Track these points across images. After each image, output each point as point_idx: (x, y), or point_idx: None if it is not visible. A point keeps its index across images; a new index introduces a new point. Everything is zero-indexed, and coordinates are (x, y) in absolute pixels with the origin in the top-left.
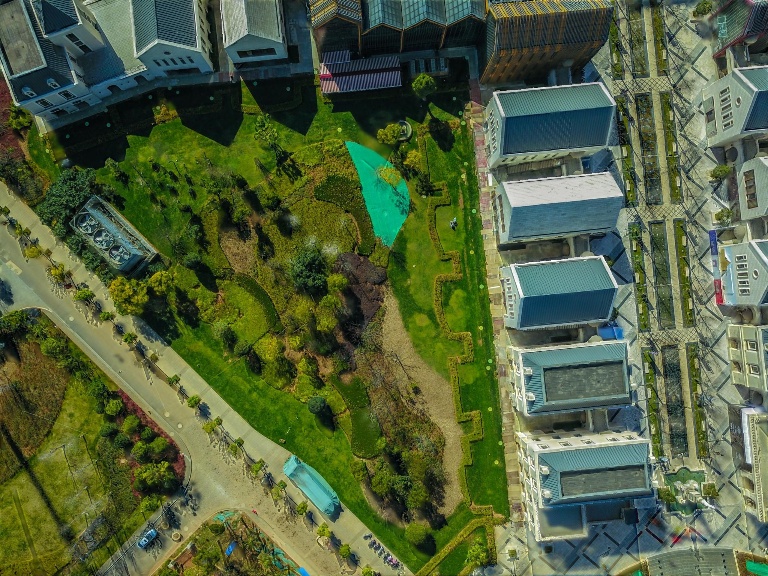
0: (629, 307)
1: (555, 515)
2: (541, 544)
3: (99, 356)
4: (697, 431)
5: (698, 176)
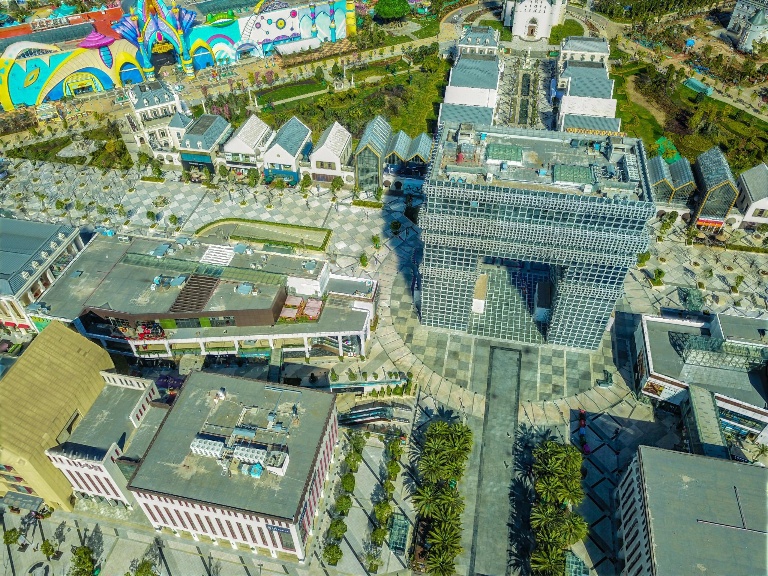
0: (542, 106)
1: None
2: None
3: None
4: None
5: None
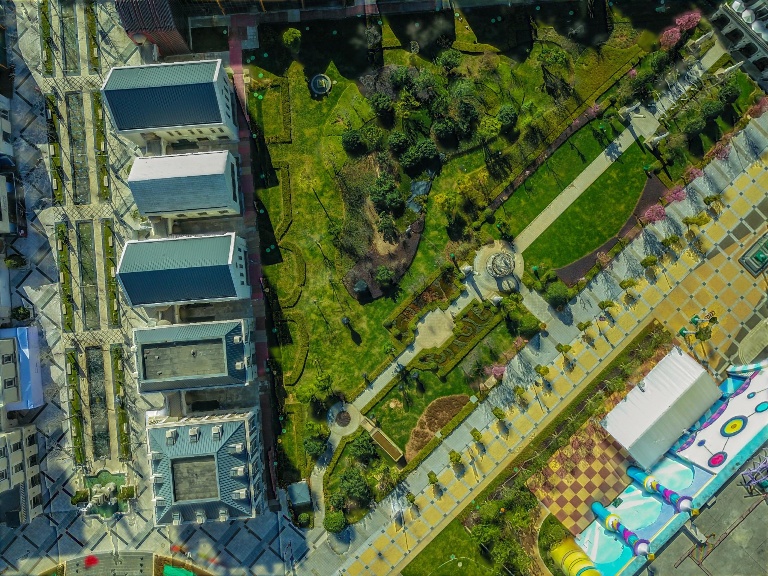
0: (54, 307)
1: None
2: None
3: None
4: (120, 433)
5: (127, 176)
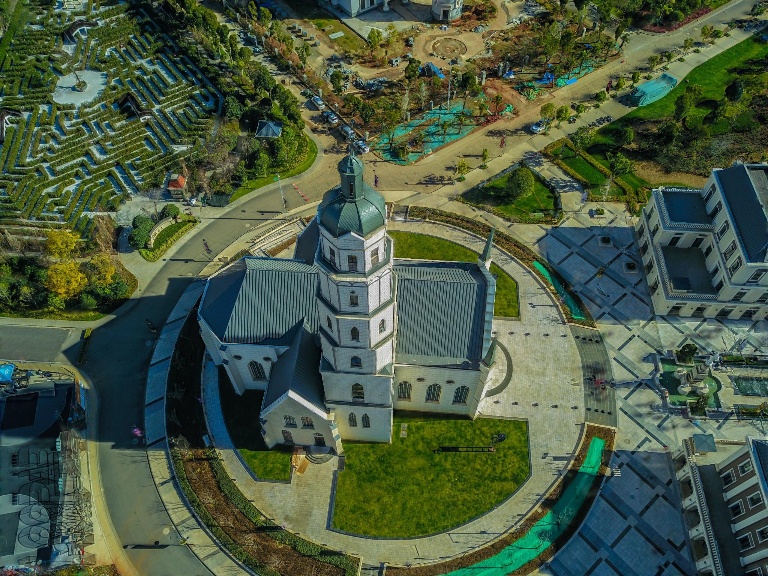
0: None
1: (683, 206)
2: (610, 236)
3: (735, 4)
4: None
5: None
